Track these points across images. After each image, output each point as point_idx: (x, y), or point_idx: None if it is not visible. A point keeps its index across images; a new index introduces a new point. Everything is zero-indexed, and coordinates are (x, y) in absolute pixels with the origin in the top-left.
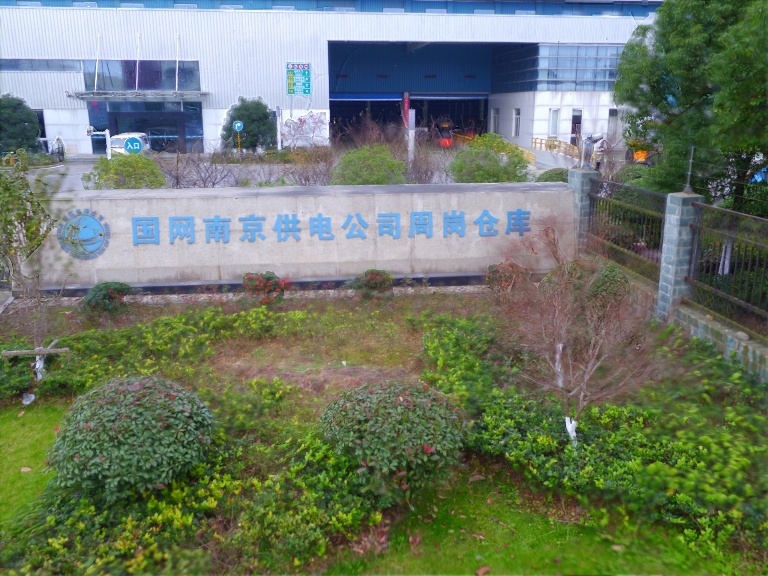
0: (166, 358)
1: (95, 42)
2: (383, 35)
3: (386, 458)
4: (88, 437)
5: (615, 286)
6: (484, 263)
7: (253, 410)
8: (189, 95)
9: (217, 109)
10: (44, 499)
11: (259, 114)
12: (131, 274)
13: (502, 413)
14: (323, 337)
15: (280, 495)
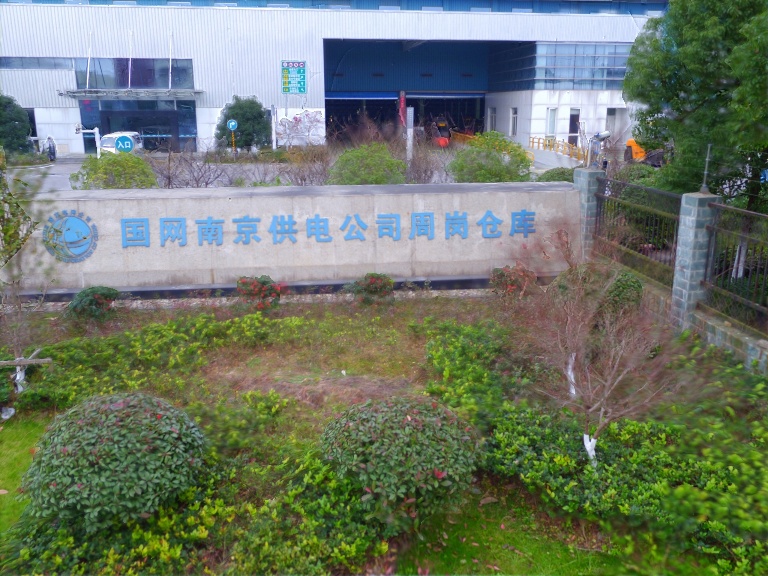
0: (155, 368)
1: (87, 40)
2: (379, 33)
3: (393, 484)
4: (65, 462)
5: (628, 291)
6: (487, 266)
7: (247, 426)
8: (182, 94)
9: (211, 108)
10: (18, 529)
11: (254, 113)
12: (120, 278)
13: (515, 429)
14: (321, 345)
15: (277, 523)
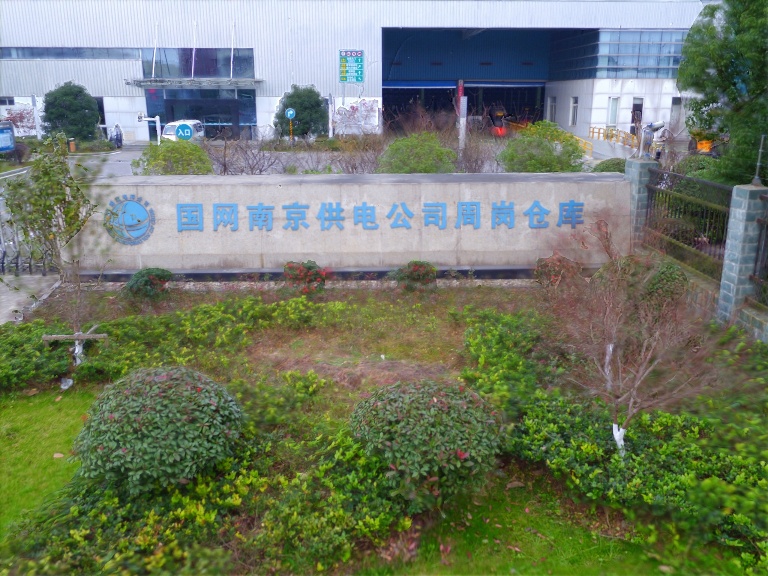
0: (202, 347)
1: (153, 30)
2: (438, 21)
3: (417, 462)
4: (112, 428)
5: (672, 284)
6: (533, 256)
7: (285, 403)
8: (243, 83)
9: (270, 97)
10: (70, 488)
11: (311, 102)
12: (175, 260)
13: (545, 416)
14: (362, 329)
15: (306, 495)
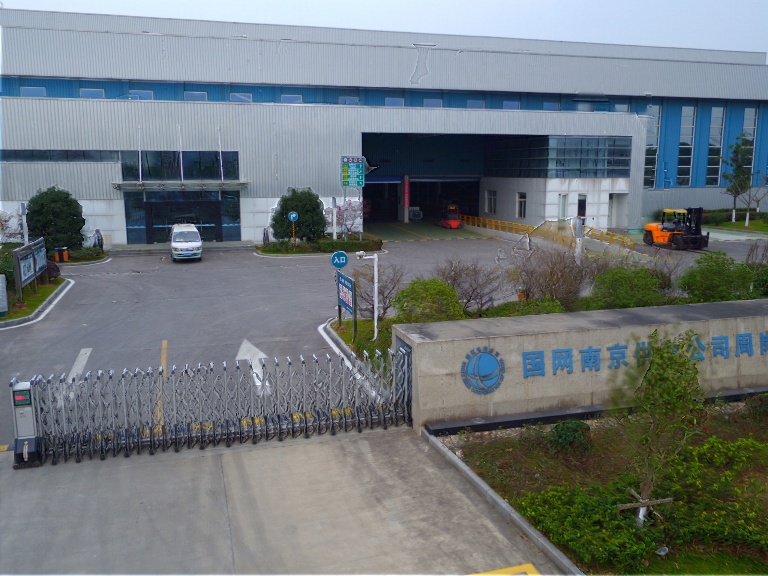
0: None
1: (135, 133)
2: (412, 128)
3: None
4: None
5: None
6: None
7: None
8: (236, 186)
9: (255, 198)
10: None
11: (313, 205)
12: (521, 405)
13: None
14: None
15: None
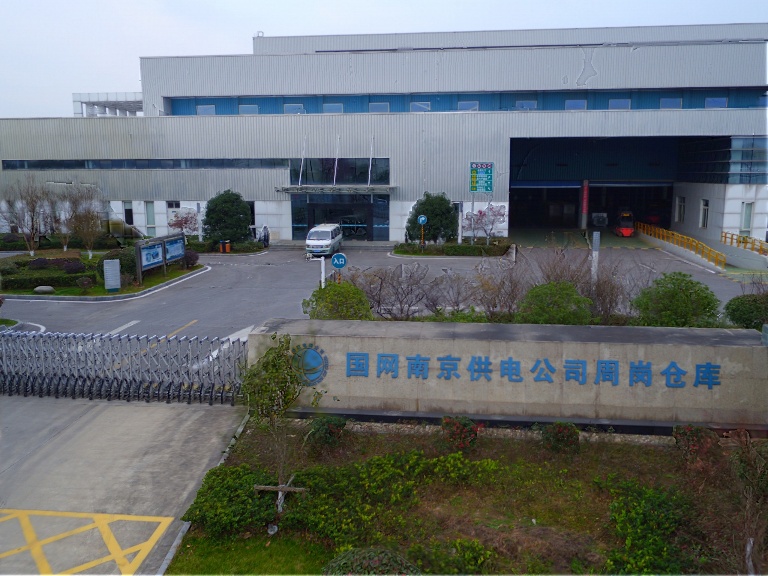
0: (381, 505)
1: (302, 143)
2: (565, 131)
3: None
4: None
5: None
6: (670, 413)
7: (459, 574)
8: (379, 190)
9: (403, 201)
10: None
11: (442, 209)
12: (343, 401)
13: None
14: (515, 492)
15: None
